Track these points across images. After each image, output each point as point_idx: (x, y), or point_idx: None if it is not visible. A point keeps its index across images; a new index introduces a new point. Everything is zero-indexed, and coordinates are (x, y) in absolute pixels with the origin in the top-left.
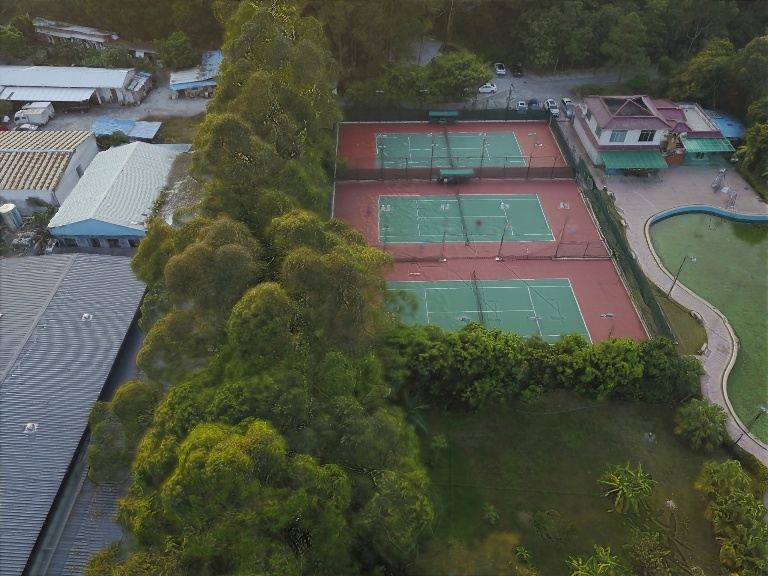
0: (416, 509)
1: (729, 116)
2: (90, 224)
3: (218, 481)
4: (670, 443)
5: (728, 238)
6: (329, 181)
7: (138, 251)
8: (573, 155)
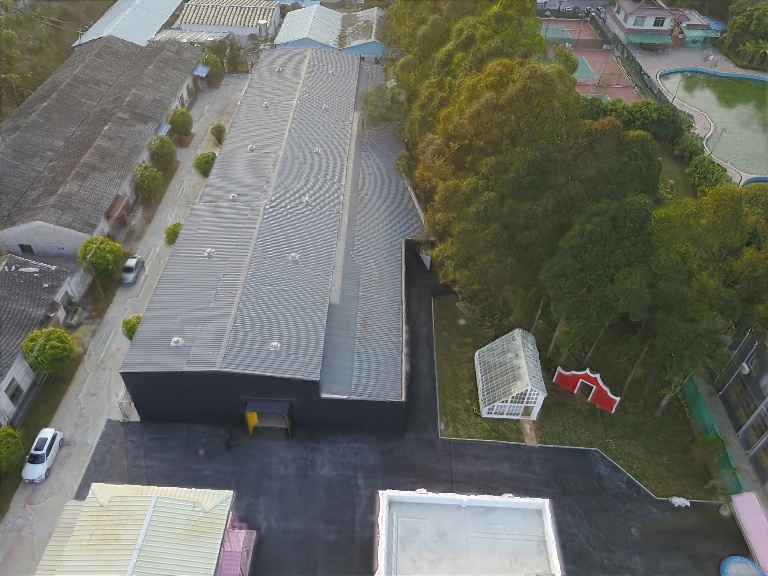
0: (573, 58)
1: (716, 19)
2: (304, 42)
3: (520, 0)
4: (671, 161)
5: (711, 84)
6: None
7: (399, 3)
8: None
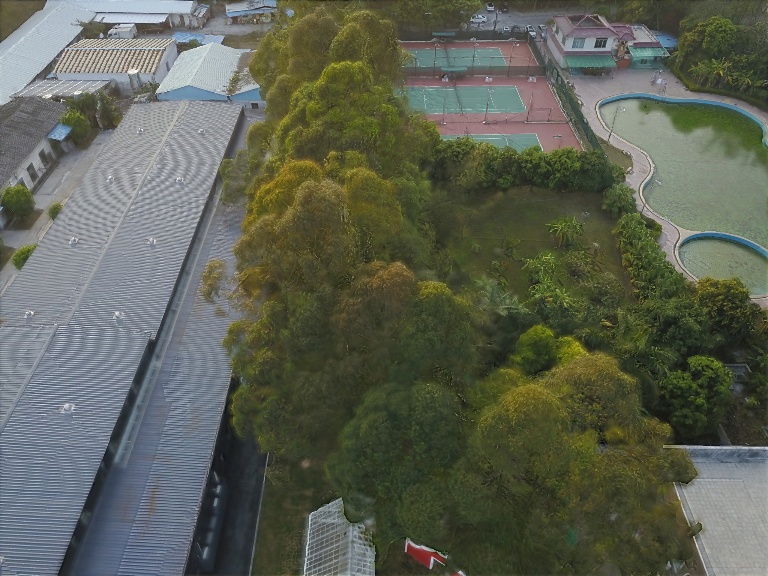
0: (431, 131)
1: (669, 34)
2: (187, 90)
3: (343, 71)
4: (599, 217)
5: (658, 113)
6: None
7: None
8: (544, 59)
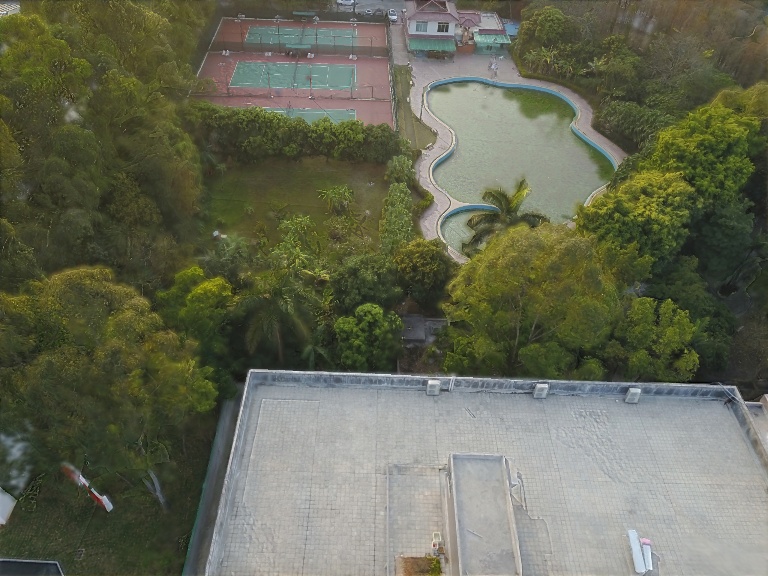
0: (126, 86)
1: (519, 23)
2: None
3: (10, 21)
4: (382, 187)
5: (485, 96)
6: (204, 51)
7: None
8: None
